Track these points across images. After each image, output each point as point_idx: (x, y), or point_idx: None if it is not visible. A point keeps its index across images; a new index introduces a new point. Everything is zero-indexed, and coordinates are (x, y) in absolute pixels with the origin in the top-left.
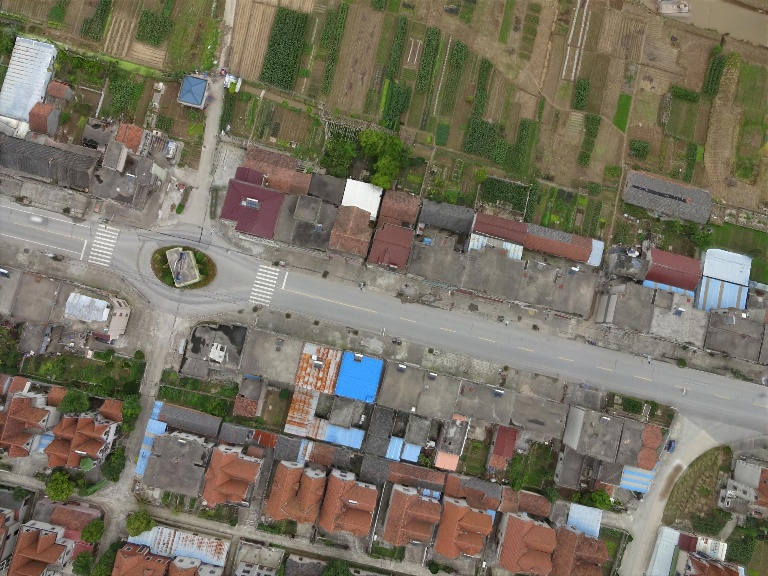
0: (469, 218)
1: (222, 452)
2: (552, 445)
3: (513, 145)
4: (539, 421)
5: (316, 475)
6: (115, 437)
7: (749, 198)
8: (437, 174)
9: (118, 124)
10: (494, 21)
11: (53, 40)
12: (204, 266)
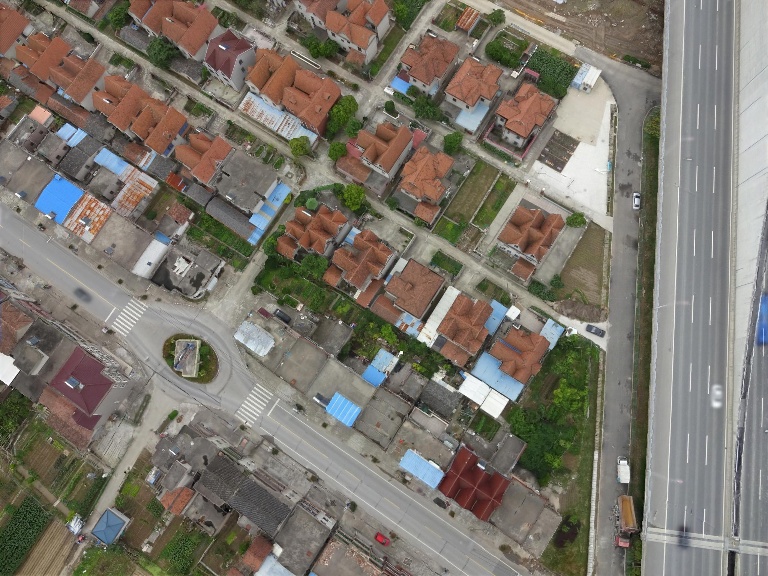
0: None
1: None
2: None
3: None
4: None
5: None
6: None
7: None
8: None
9: None
10: None
11: None
12: None
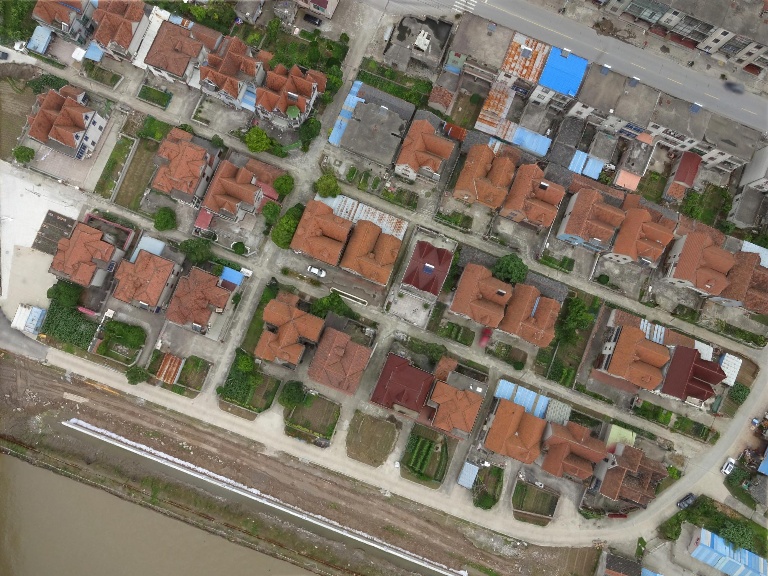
0: None
1: None
2: (728, 188)
3: None
4: (731, 142)
5: None
6: (312, 107)
7: None
8: None
9: None
10: None
11: None
12: None
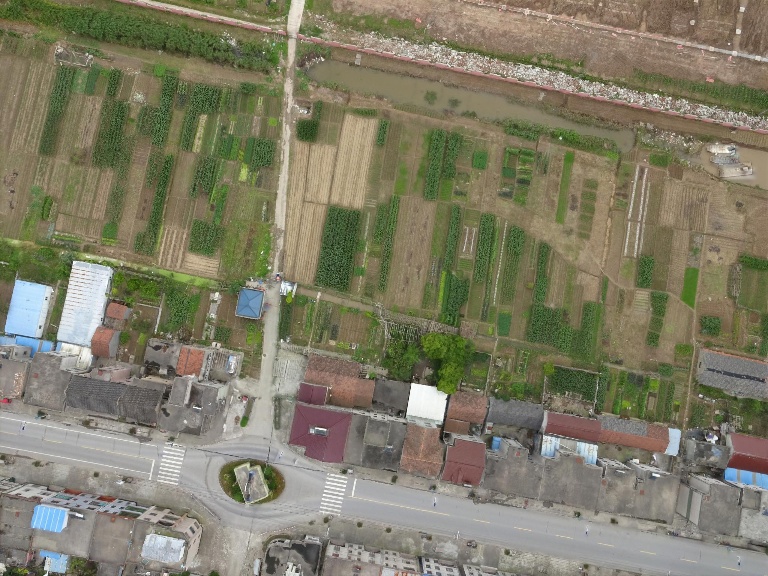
0: (539, 416)
1: None
2: None
3: (578, 331)
4: None
5: None
6: None
7: None
8: (501, 366)
9: (178, 340)
10: (550, 201)
11: (108, 257)
12: (272, 480)
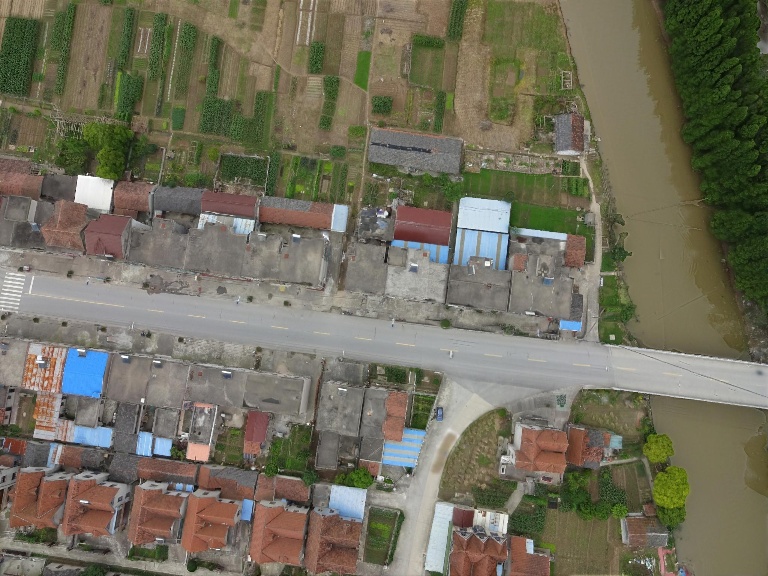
0: None
1: None
2: (312, 425)
3: (249, 119)
4: (274, 400)
5: (59, 478)
6: None
7: (507, 140)
8: (175, 159)
9: None
10: None
11: None
12: None
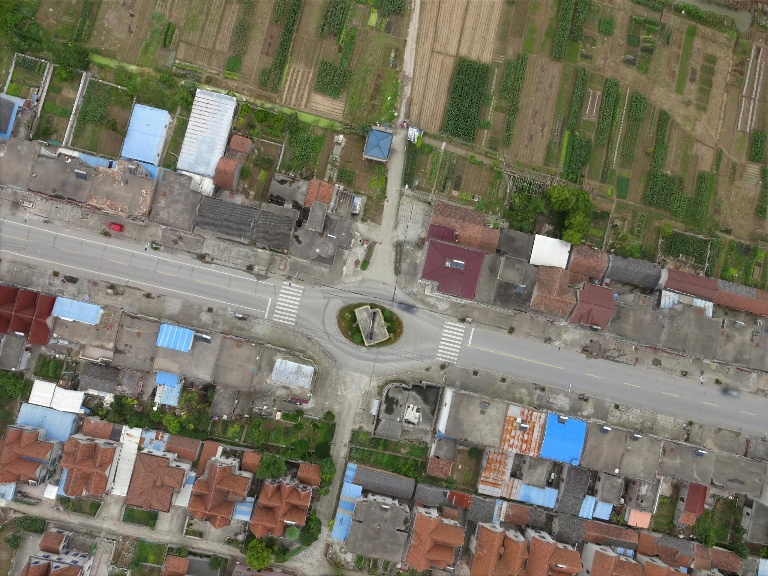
0: (657, 274)
1: (430, 518)
2: (737, 500)
3: (692, 198)
4: (739, 480)
5: (517, 537)
6: None
7: None
8: (618, 227)
9: (301, 178)
10: (671, 72)
11: None
12: (391, 324)
